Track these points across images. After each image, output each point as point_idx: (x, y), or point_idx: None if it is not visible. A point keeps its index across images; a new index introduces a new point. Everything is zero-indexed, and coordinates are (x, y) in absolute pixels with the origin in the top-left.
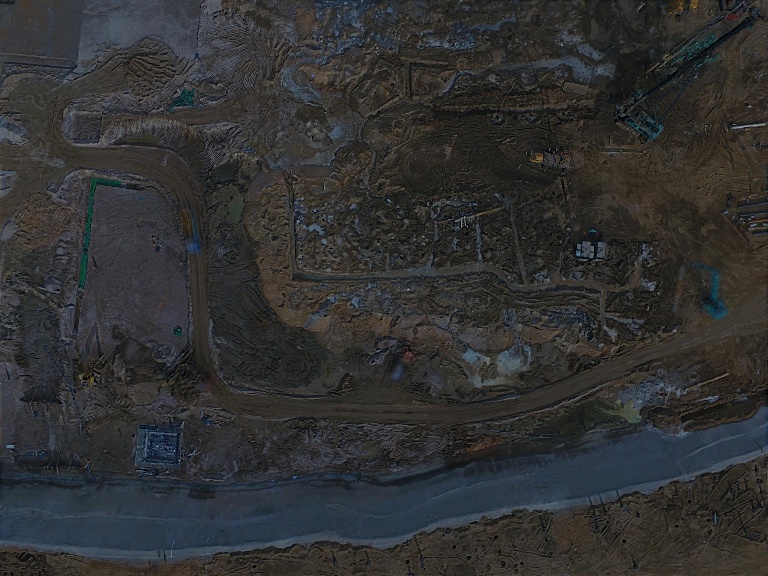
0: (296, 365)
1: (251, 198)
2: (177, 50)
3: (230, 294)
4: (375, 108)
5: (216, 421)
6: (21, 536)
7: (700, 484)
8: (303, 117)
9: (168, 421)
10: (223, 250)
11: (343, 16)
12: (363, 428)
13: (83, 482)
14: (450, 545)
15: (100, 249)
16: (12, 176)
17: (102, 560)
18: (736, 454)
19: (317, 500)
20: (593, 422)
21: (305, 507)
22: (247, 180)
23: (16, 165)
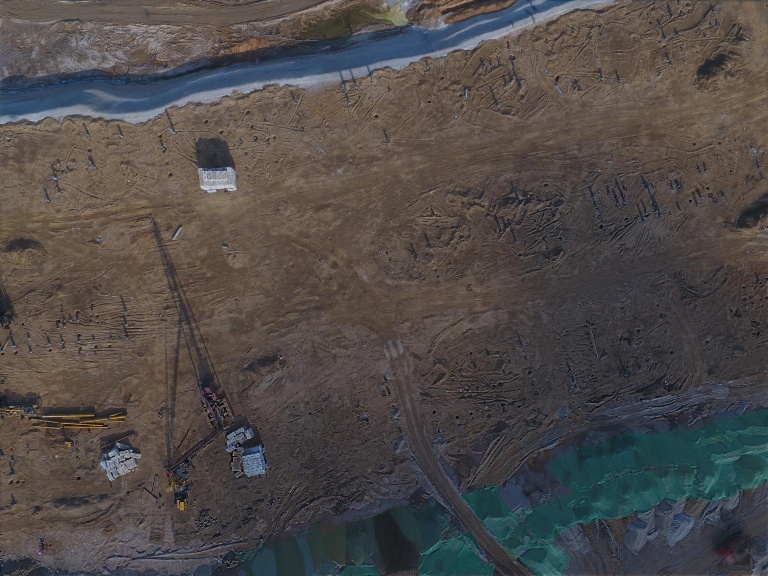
0: None
1: None
2: None
3: None
4: None
5: None
6: None
7: (452, 60)
8: None
9: None
10: None
11: None
12: (129, 31)
13: None
14: (202, 120)
15: None
16: None
17: None
18: (488, 31)
19: (78, 89)
20: (359, 25)
21: (64, 94)
22: None
23: None
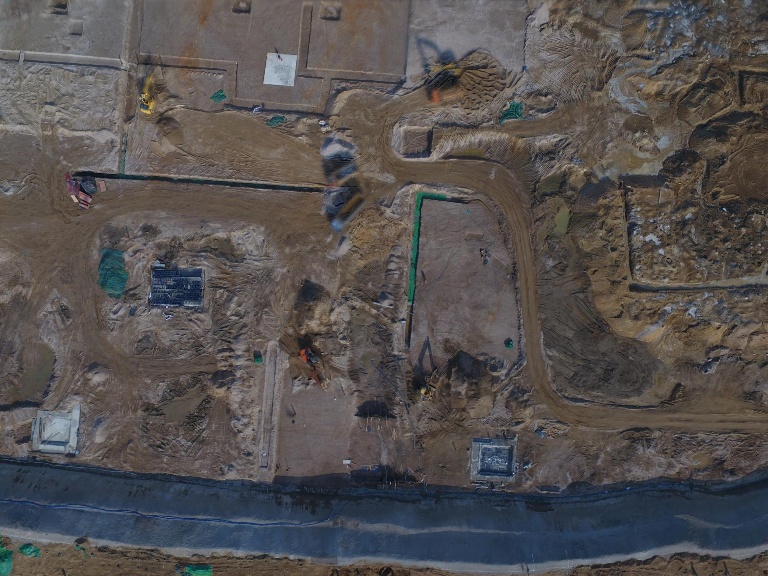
0: (629, 376)
1: (582, 209)
2: (504, 63)
3: (559, 306)
4: (707, 117)
5: (549, 433)
6: (385, 552)
7: None
8: (631, 127)
9: (502, 434)
10: (552, 262)
11: (675, 25)
12: (697, 438)
13: (419, 496)
14: None
15: (429, 263)
16: (345, 192)
17: (466, 575)
18: None
19: (663, 511)
20: None
21: (654, 518)
22: (575, 191)
23: (348, 181)
